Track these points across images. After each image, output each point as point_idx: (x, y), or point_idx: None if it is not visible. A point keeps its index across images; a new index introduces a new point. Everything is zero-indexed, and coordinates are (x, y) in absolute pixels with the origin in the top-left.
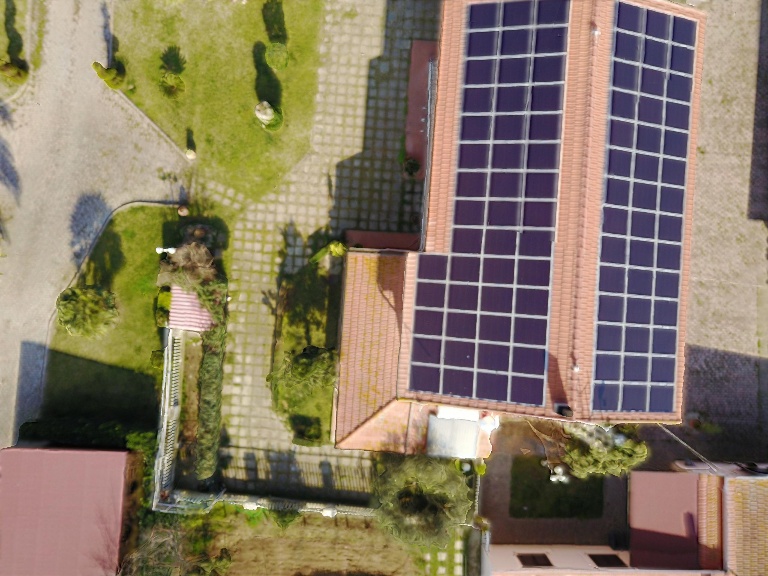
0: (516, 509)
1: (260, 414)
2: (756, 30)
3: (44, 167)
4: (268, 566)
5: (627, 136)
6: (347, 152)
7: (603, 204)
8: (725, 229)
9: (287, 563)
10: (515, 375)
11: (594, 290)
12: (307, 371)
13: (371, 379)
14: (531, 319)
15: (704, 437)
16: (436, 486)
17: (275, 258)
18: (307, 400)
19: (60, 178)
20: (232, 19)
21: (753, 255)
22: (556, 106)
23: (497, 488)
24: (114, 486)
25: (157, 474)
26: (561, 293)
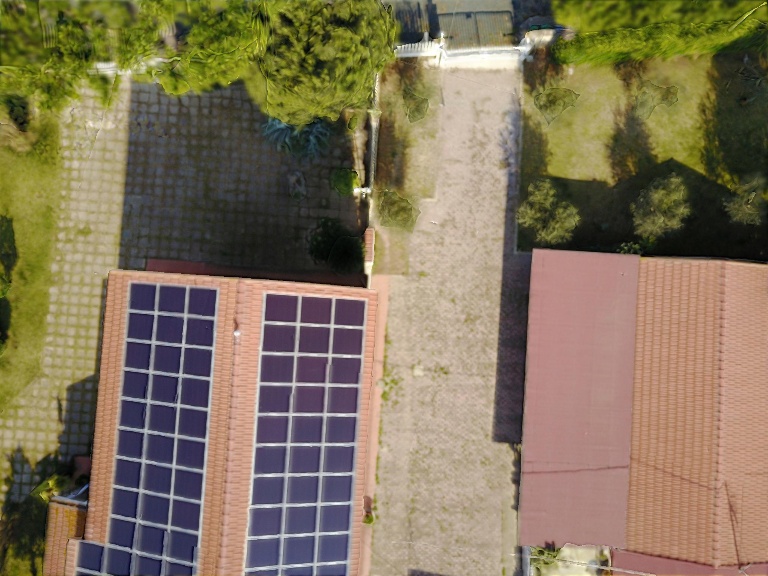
0: None
1: None
2: (500, 248)
3: None
4: None
5: (279, 431)
6: (78, 375)
7: (249, 506)
8: (469, 452)
9: None
10: None
11: None
12: None
13: None
14: None
15: None
16: None
17: (1, 486)
18: None
19: None
20: None
21: (498, 479)
22: (202, 402)
23: None
24: None
25: None
26: None
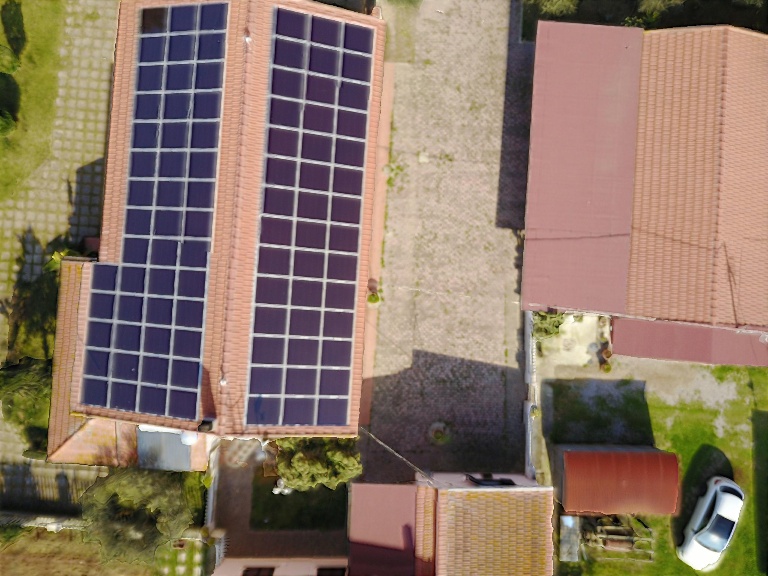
0: (256, 522)
1: None
2: (505, 37)
3: None
4: None
5: (290, 145)
6: (88, 158)
7: (261, 214)
8: (473, 237)
9: None
10: (172, 389)
11: (250, 302)
12: (5, 383)
13: None
14: (188, 331)
15: (450, 448)
16: (145, 501)
17: (13, 266)
18: (43, 412)
19: None
20: None
21: (501, 264)
22: (214, 114)
23: (238, 501)
24: None
25: None
26: (214, 305)
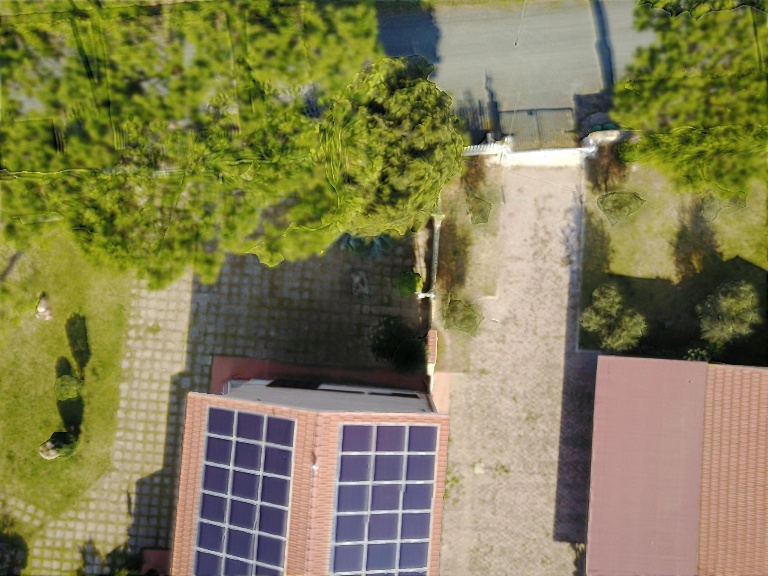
0: None
1: None
2: (561, 346)
3: None
4: None
5: (355, 559)
6: (147, 469)
7: None
8: (530, 551)
9: None
10: None
11: None
12: None
13: None
14: None
15: None
16: None
17: None
18: None
19: None
20: (35, 334)
21: None
22: (280, 531)
23: None
24: None
25: None
26: None
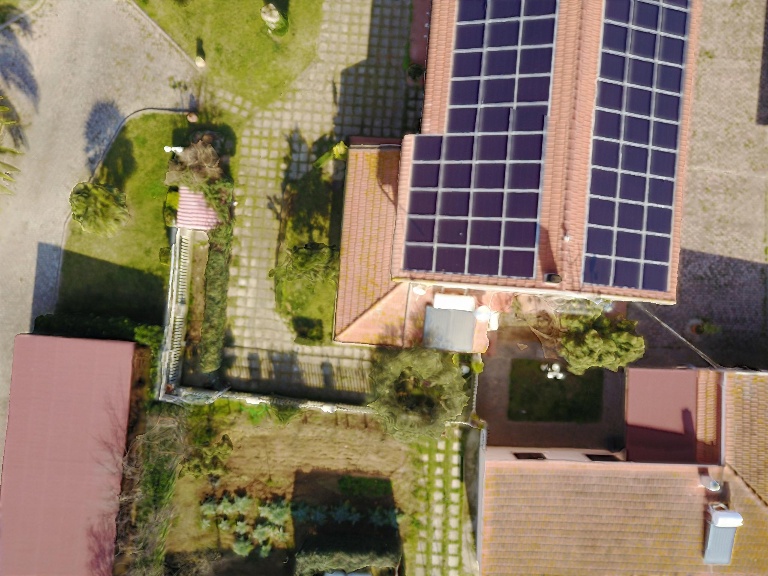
0: (515, 412)
1: (264, 315)
2: None
3: (61, 76)
4: (270, 463)
5: (623, 11)
6: (352, 60)
7: (597, 78)
8: (733, 135)
9: (289, 460)
10: (506, 249)
11: (586, 163)
12: (307, 261)
13: (370, 272)
14: (523, 193)
15: (708, 345)
16: (432, 377)
17: (280, 164)
18: (310, 302)
19: (76, 86)
20: None
21: (762, 161)
22: None
23: (496, 392)
24: (122, 374)
25: (164, 366)
26: (553, 166)
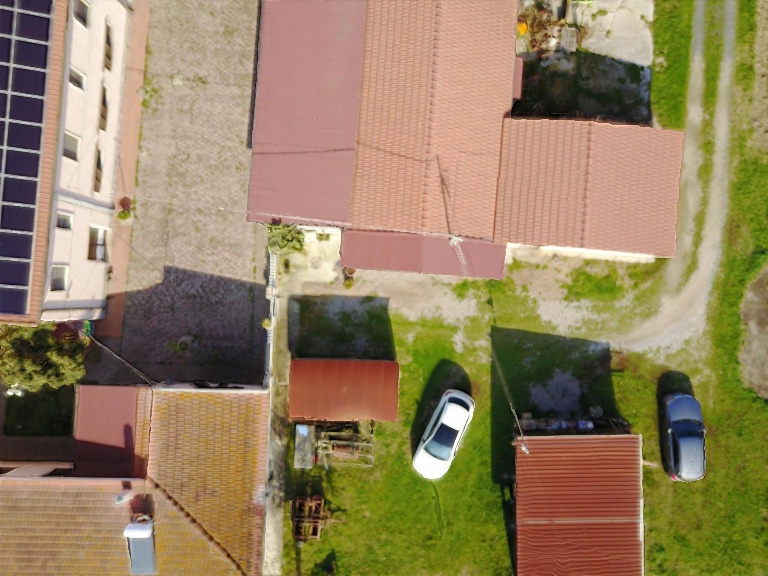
0: (10, 427)
1: None
2: None
3: None
4: None
5: None
6: None
7: None
8: (225, 158)
9: None
10: None
11: None
12: None
13: None
14: None
15: (199, 360)
16: None
17: None
18: None
19: None
20: None
21: None
22: None
23: None
24: None
25: None
26: None
